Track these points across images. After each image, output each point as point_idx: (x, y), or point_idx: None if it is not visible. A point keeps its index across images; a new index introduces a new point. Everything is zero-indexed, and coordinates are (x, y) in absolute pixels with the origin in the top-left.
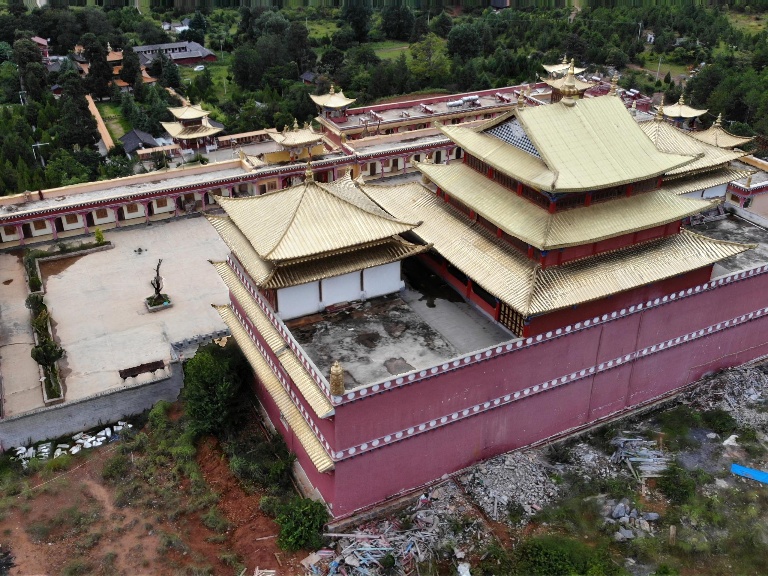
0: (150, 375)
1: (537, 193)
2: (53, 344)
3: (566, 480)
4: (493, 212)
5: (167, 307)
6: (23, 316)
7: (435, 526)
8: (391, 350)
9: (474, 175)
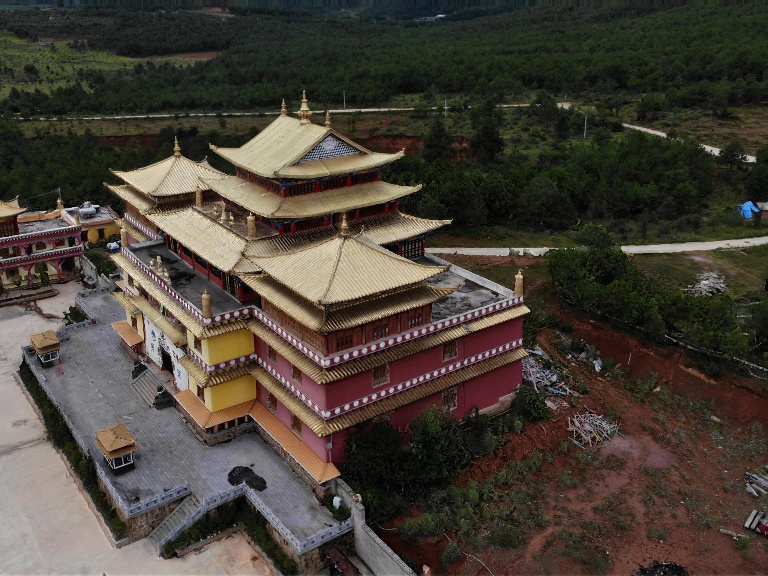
0: None
1: (366, 174)
2: None
3: None
4: (359, 201)
5: None
6: None
7: None
8: None
9: (307, 197)
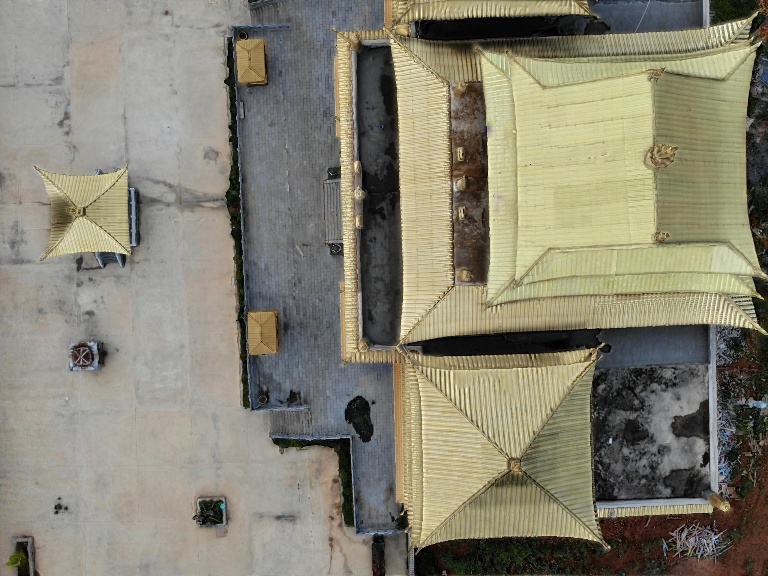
0: (352, 546)
1: None
2: None
3: None
4: (645, 286)
5: (225, 504)
6: None
7: None
8: (660, 421)
9: None
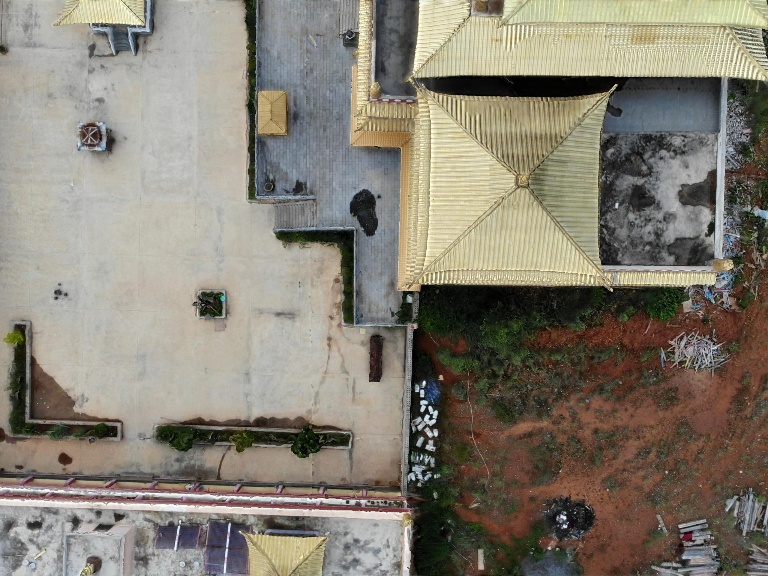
0: (350, 347)
1: None
2: (307, 437)
3: (733, 90)
4: (661, 15)
5: (226, 298)
6: (164, 451)
7: None
8: (667, 188)
9: None
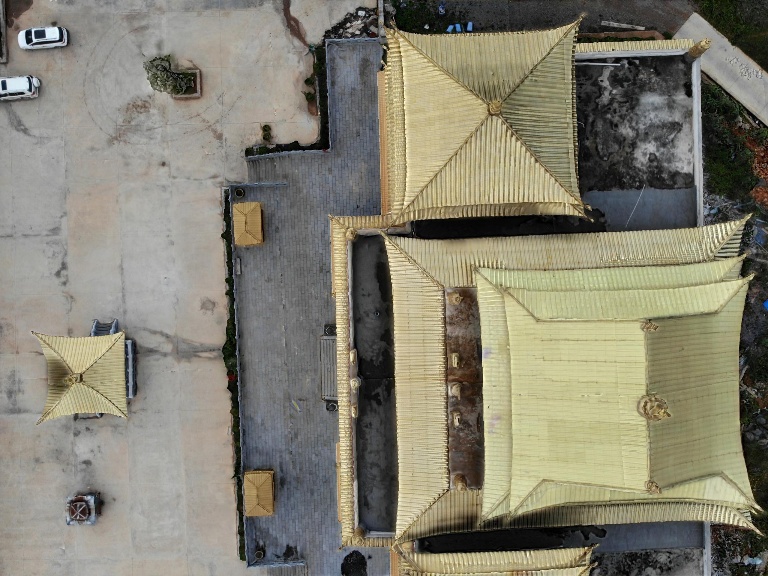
0: None
1: None
2: None
3: None
4: None
5: None
6: None
7: (711, 566)
8: None
9: None
